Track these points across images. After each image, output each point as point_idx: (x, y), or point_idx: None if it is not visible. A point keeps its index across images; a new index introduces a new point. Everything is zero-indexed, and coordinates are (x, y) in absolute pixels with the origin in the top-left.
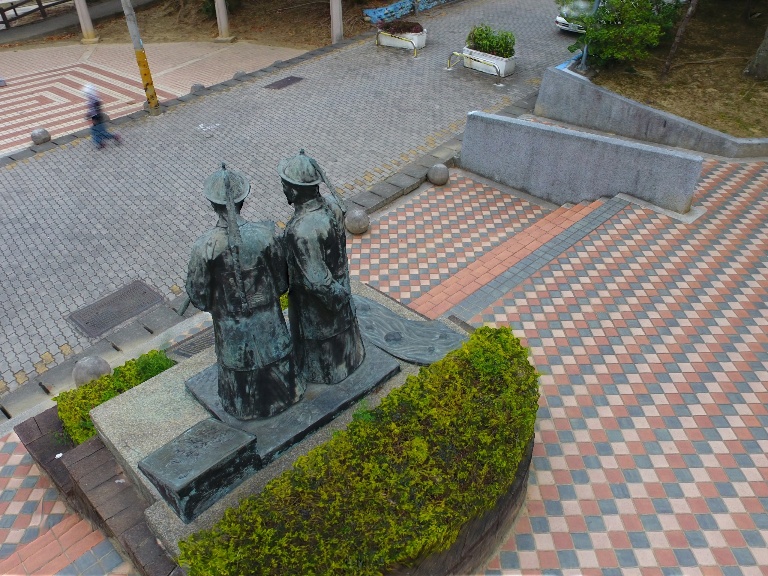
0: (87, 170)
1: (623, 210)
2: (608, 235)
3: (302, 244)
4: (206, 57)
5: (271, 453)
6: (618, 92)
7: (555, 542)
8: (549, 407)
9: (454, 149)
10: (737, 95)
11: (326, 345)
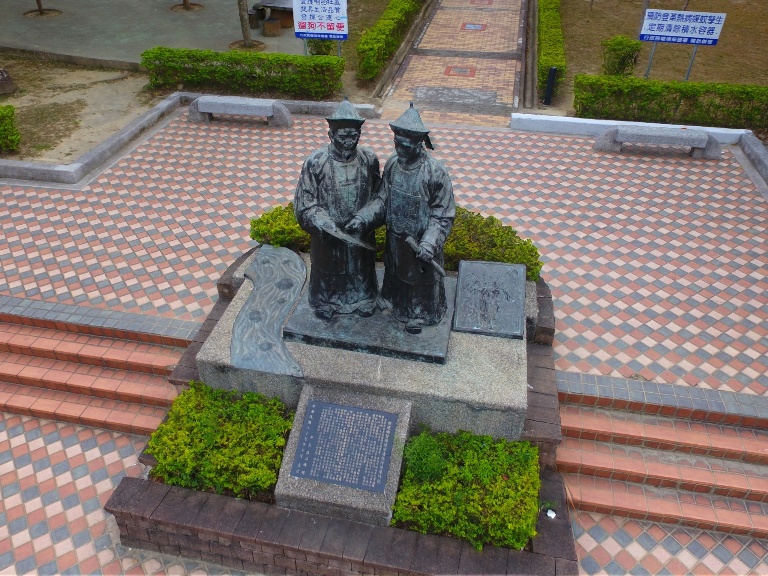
0: None
1: None
2: None
3: None
4: None
5: None
6: None
7: None
8: None
9: None
10: None
11: None
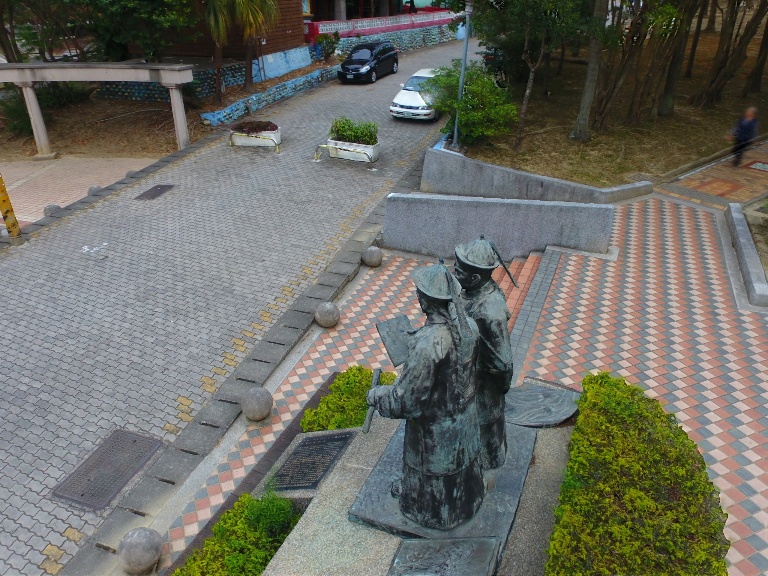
0: None
1: (561, 259)
2: (567, 282)
3: (496, 326)
4: (34, 177)
5: None
6: (490, 163)
7: (740, 551)
8: None
9: (371, 232)
10: (574, 156)
11: (495, 427)
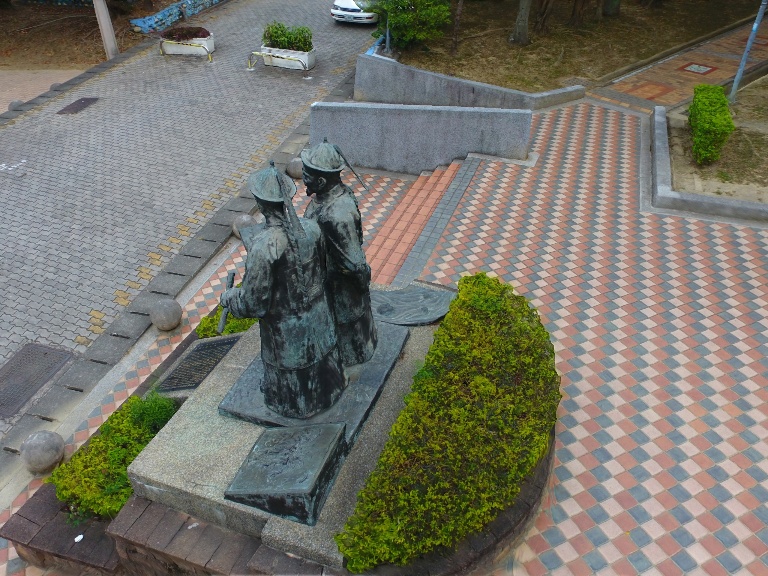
0: None
1: (480, 166)
2: (481, 188)
3: (343, 228)
4: None
5: (353, 436)
6: (424, 69)
7: (587, 429)
8: None
9: (299, 143)
10: (512, 60)
11: (357, 325)
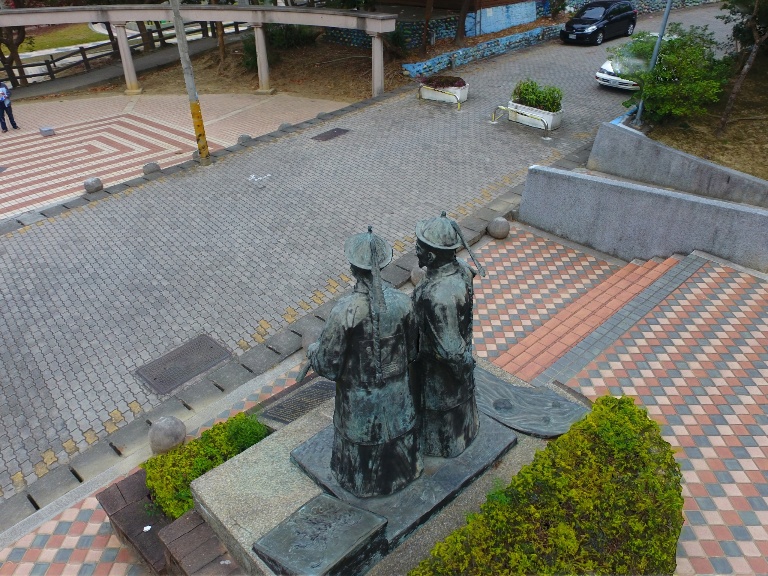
0: (142, 219)
1: (702, 268)
2: (693, 294)
3: (440, 311)
4: (248, 108)
5: (398, 537)
6: (675, 147)
7: None
8: None
9: (511, 202)
10: None
11: (448, 416)
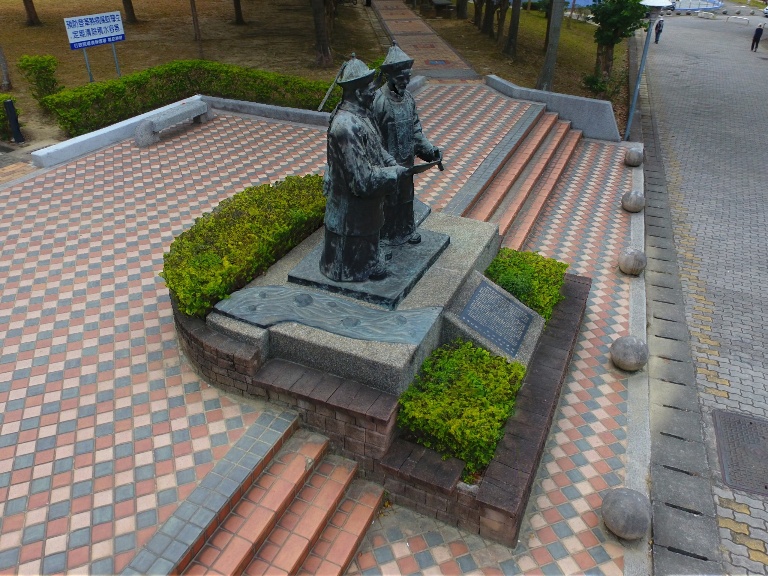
0: None
1: None
2: None
3: None
4: None
5: None
6: None
7: None
8: (147, 362)
9: None
10: None
11: None
